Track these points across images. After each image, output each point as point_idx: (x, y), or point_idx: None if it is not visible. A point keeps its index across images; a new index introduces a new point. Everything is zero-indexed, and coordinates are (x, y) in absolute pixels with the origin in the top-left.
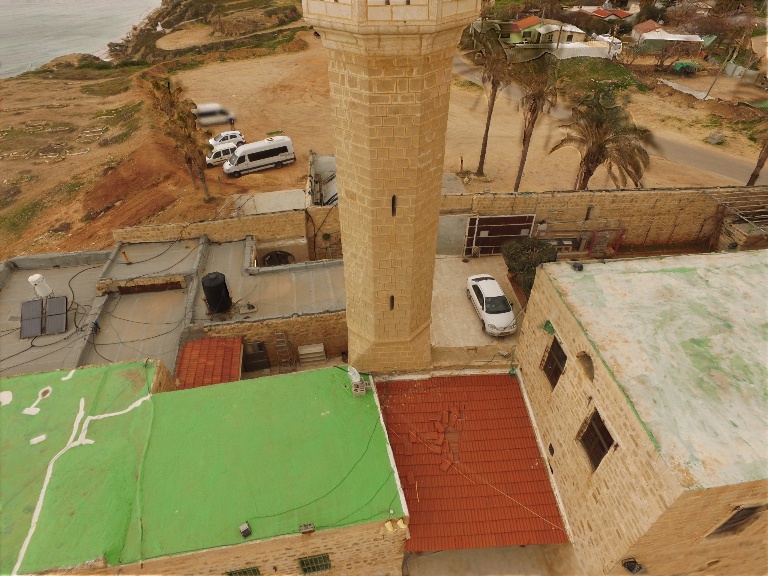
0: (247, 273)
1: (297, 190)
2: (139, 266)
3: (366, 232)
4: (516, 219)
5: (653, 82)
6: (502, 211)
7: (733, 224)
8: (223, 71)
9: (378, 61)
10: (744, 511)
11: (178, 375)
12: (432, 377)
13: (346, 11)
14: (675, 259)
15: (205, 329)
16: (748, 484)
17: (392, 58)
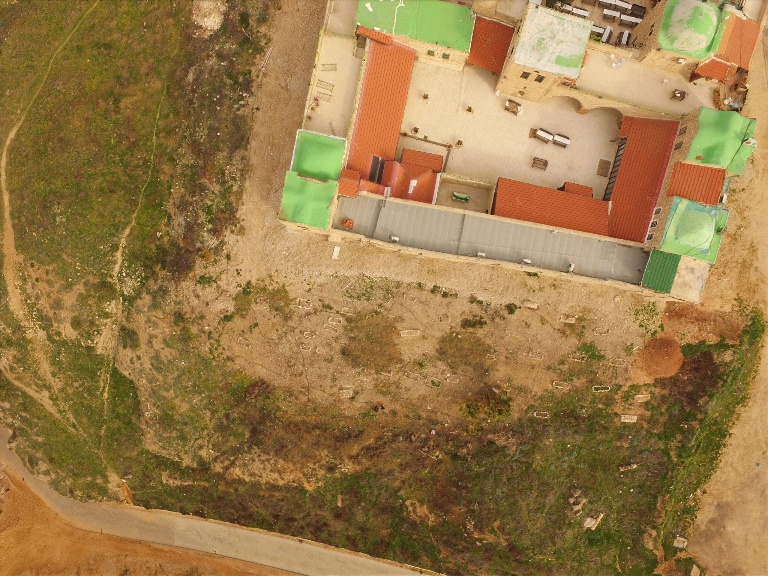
0: None
1: None
2: None
3: None
4: None
5: None
6: None
7: None
8: None
9: None
10: (524, 72)
11: None
12: (492, 20)
13: None
14: (564, 14)
15: None
16: (523, 65)
17: None
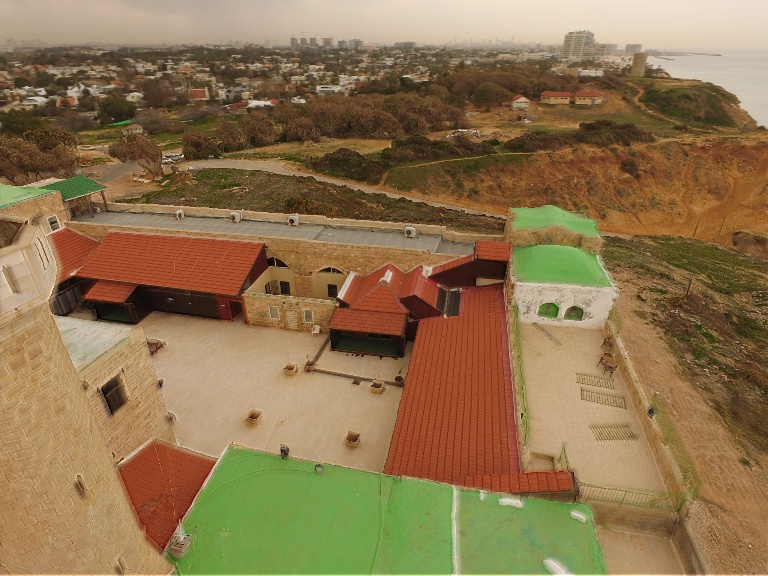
0: None
1: None
2: None
3: None
4: None
5: None
6: None
7: None
8: None
9: None
10: None
11: None
12: None
13: None
14: None
15: None
16: None
17: None
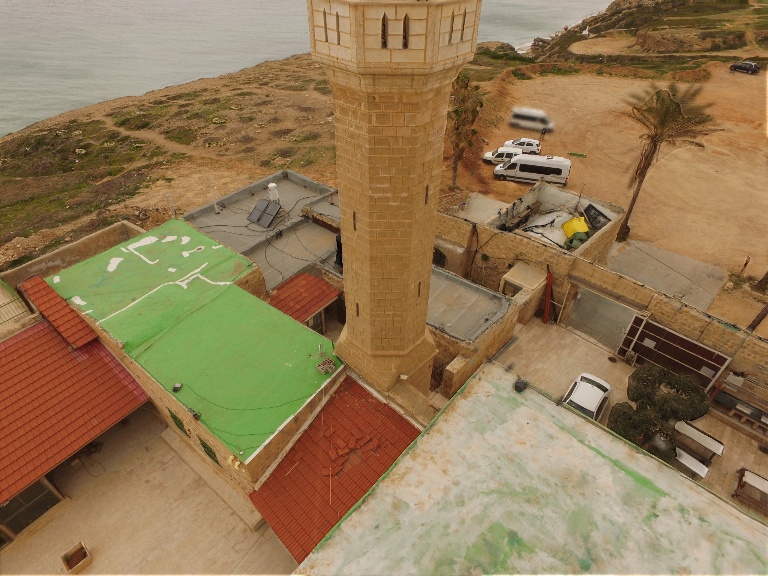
0: None
1: None
2: (335, 208)
3: None
4: (699, 349)
5: None
6: (686, 330)
7: None
8: (589, 84)
9: (338, 88)
10: None
11: (279, 288)
12: (387, 404)
13: None
14: (656, 466)
15: (323, 271)
16: None
17: (346, 89)
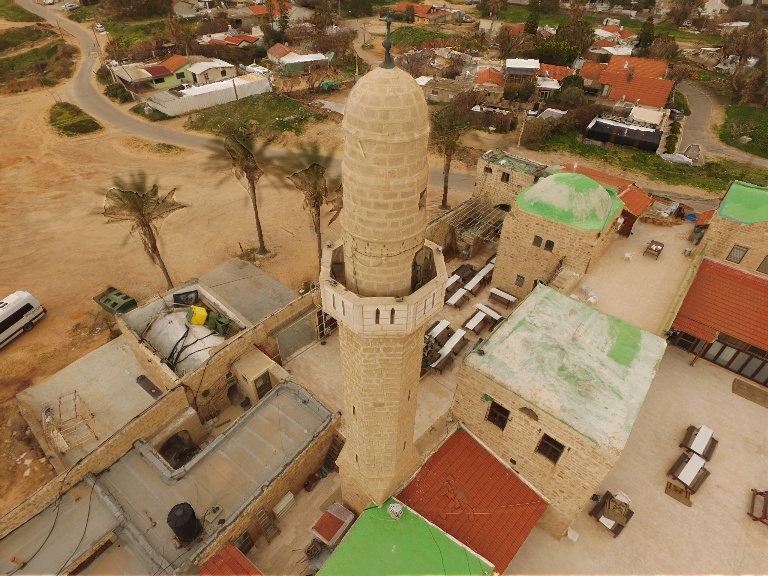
0: (174, 480)
1: (96, 351)
2: (40, 559)
3: (392, 420)
4: None
5: (324, 111)
6: None
7: (462, 233)
8: None
9: (408, 335)
10: None
11: None
12: (422, 466)
13: (401, 327)
14: (512, 317)
15: (195, 563)
16: None
17: None
